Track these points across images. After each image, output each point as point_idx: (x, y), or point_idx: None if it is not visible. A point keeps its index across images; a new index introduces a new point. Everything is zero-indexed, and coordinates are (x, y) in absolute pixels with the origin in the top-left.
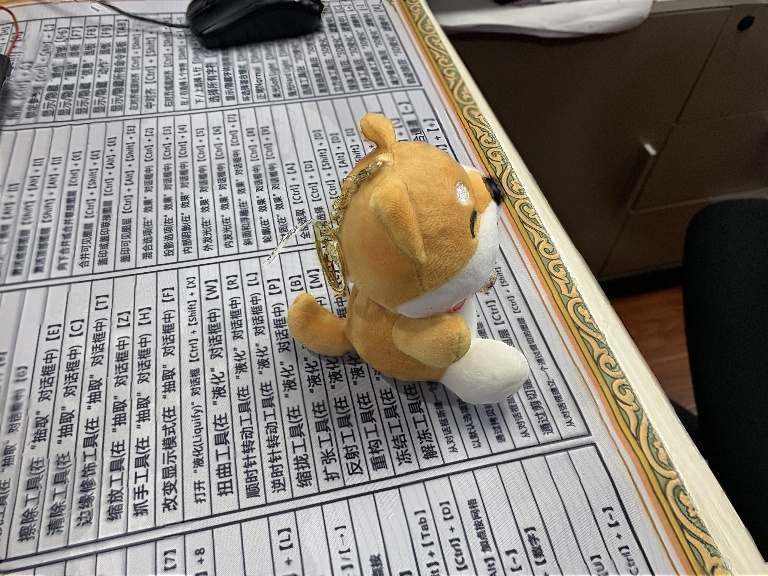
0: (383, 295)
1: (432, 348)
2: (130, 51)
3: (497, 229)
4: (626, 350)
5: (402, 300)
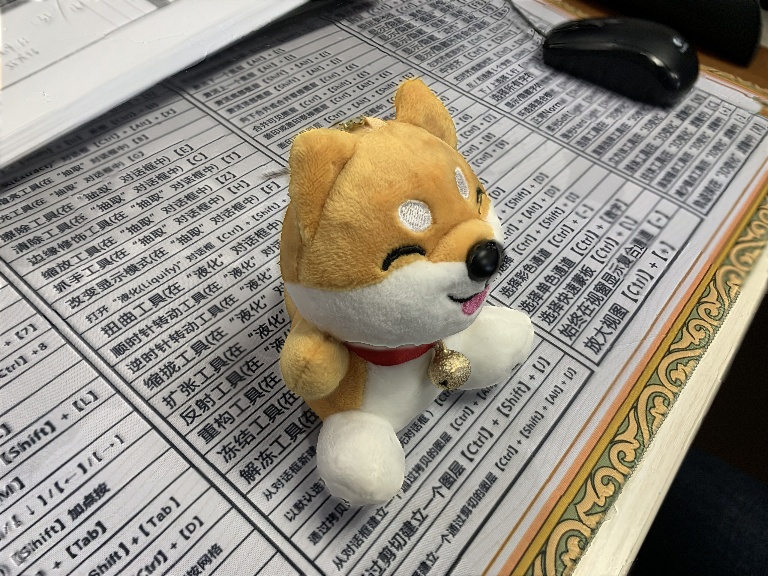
0: None
1: None
2: (484, 30)
3: (455, 306)
4: None
5: None
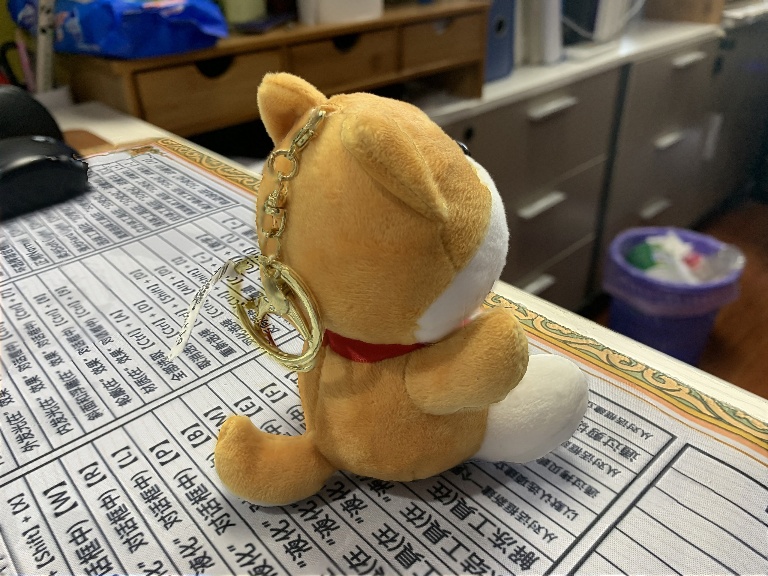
0: (396, 306)
1: (488, 367)
2: None
3: None
4: (622, 345)
5: (427, 301)
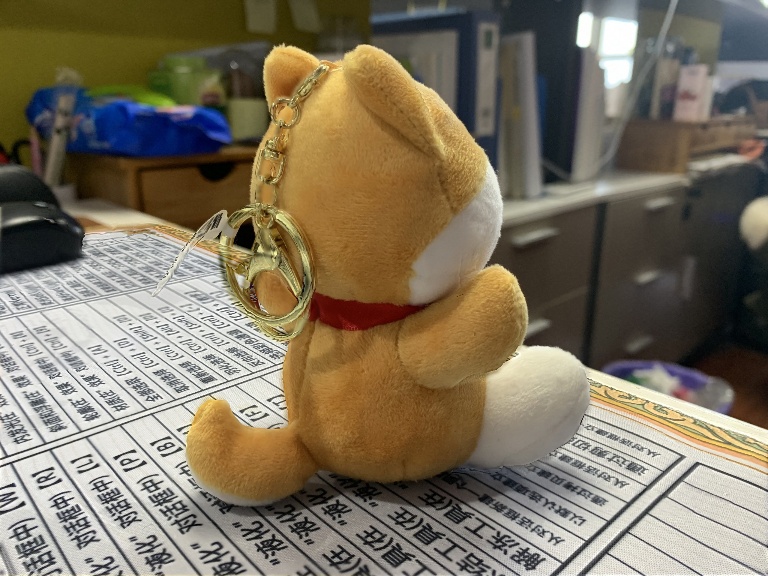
0: (392, 243)
1: (486, 320)
2: None
3: None
4: (620, 386)
5: (424, 241)
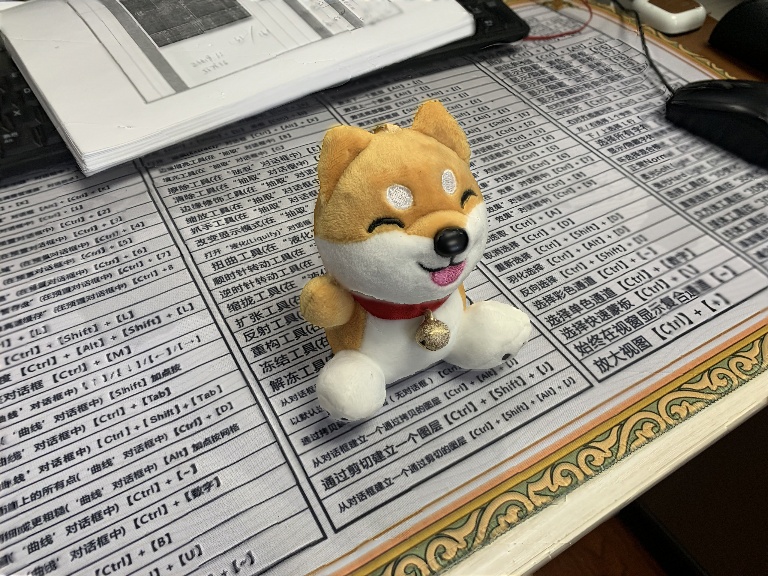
0: None
1: None
2: (616, 82)
3: (424, 273)
4: None
5: None
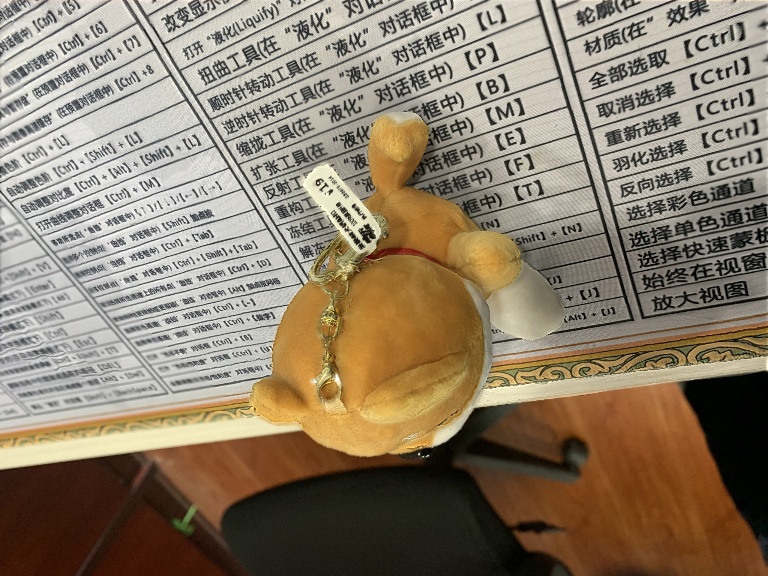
0: None
1: None
2: None
3: None
4: None
5: None
